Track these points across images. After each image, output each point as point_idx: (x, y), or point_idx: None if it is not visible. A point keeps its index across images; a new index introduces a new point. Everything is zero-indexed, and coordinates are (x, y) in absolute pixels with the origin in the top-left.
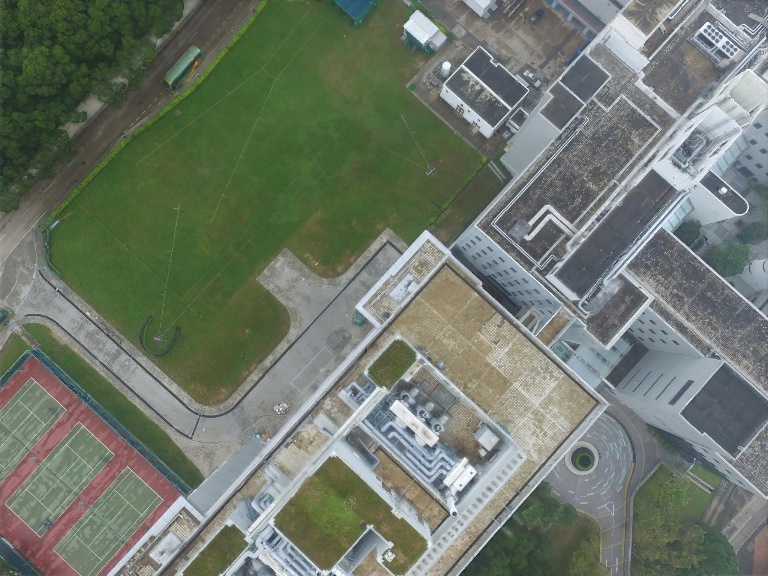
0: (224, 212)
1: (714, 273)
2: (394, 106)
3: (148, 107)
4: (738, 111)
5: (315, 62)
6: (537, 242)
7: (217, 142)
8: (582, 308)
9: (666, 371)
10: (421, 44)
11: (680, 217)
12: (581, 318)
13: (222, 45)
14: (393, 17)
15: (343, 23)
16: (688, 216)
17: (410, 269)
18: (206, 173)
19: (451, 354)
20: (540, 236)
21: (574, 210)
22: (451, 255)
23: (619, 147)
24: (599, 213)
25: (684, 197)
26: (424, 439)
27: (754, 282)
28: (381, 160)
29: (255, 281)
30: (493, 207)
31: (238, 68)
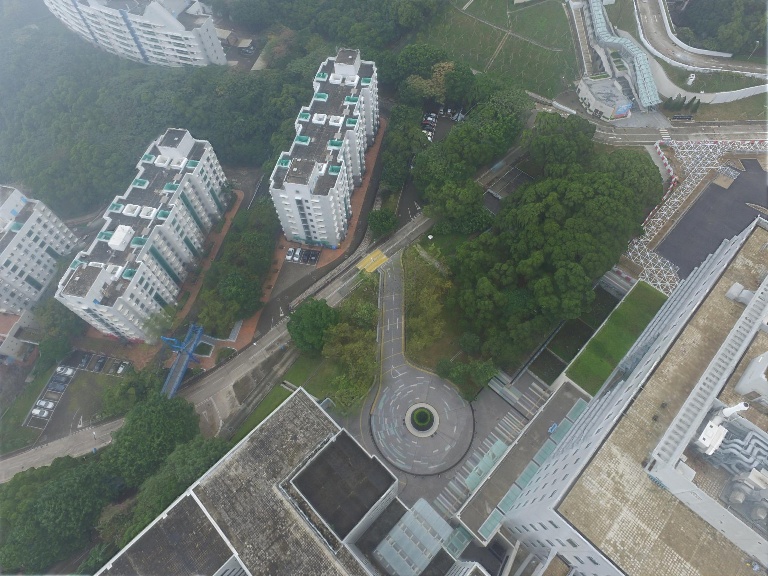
0: None
1: None
2: None
3: None
4: None
5: None
6: None
7: None
8: None
9: None
10: None
11: None
12: None
13: None
14: None
15: None
16: None
17: None
18: None
19: None
20: None
21: None
22: None
23: None
24: None
25: None
26: (765, 478)
27: None
28: None
29: None
30: None
31: None
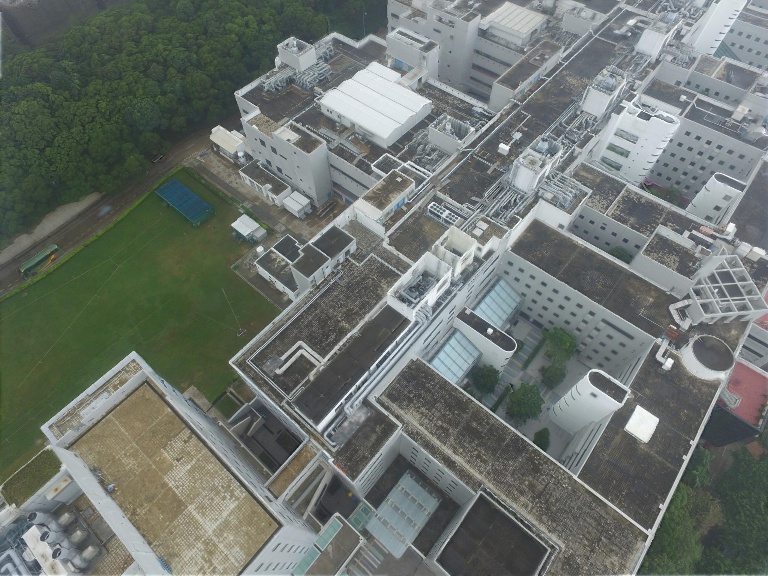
0: (35, 377)
1: (476, 402)
2: (217, 282)
3: (0, 291)
4: (449, 255)
5: (156, 253)
6: (290, 376)
7: (51, 316)
8: (328, 439)
9: (454, 521)
10: (244, 236)
11: (469, 361)
12: (330, 451)
13: (82, 244)
14: (228, 220)
15: (186, 226)
16: (481, 362)
17: (109, 388)
18: (31, 343)
19: (127, 475)
20: (294, 370)
21: (328, 346)
22: (145, 370)
23: (370, 292)
24: (341, 344)
25: (421, 327)
26: (50, 575)
27: (565, 426)
28: (197, 325)
29: (43, 445)
30: (251, 346)
31: (90, 259)
